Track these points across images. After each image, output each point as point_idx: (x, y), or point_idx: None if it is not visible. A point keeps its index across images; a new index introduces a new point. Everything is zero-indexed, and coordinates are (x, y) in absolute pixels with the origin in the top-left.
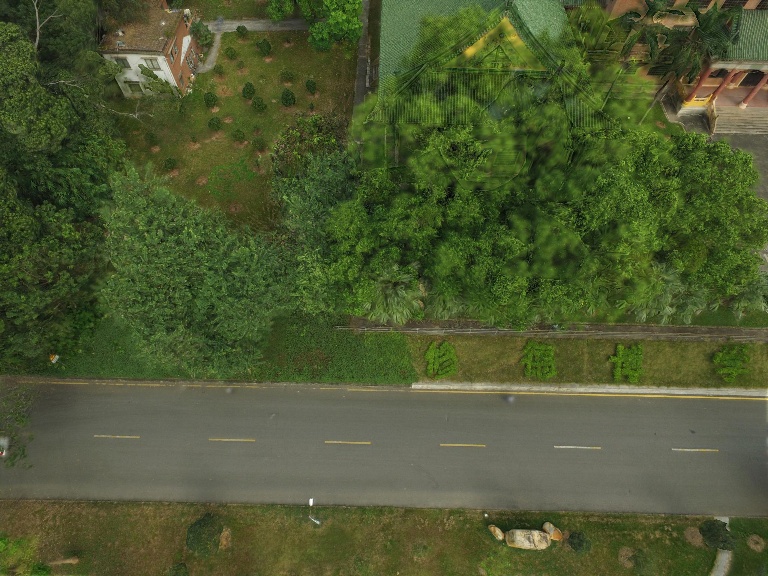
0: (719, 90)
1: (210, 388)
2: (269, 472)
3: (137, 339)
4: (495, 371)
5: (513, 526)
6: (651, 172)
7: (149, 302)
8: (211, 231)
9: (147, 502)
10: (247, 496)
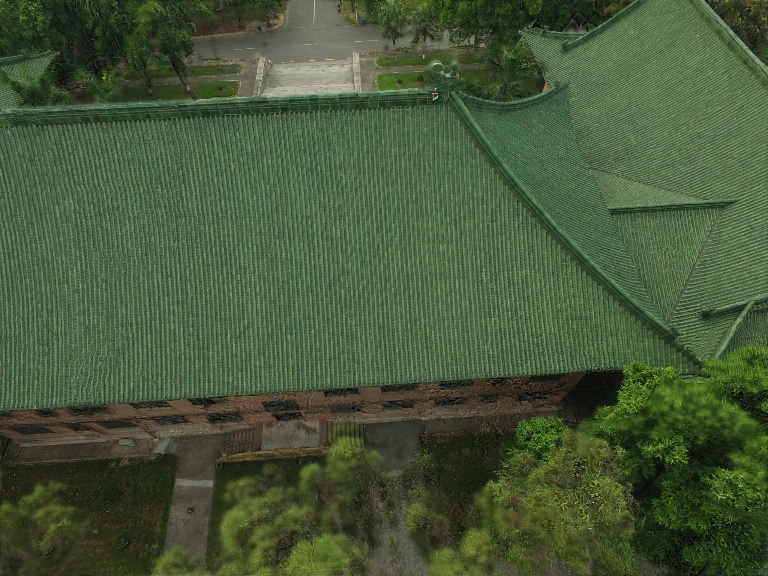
0: None
1: None
2: None
3: None
4: None
5: None
6: None
7: None
8: None
9: None
10: None
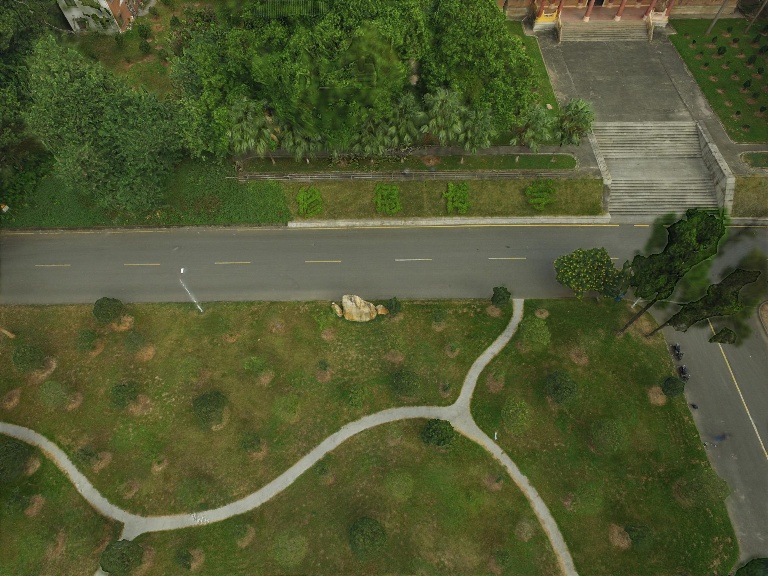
0: (561, 5)
1: (129, 233)
2: (169, 283)
3: (57, 164)
4: (353, 210)
5: None
6: (407, 3)
7: (60, 127)
8: (109, 80)
9: (72, 304)
10: (150, 298)
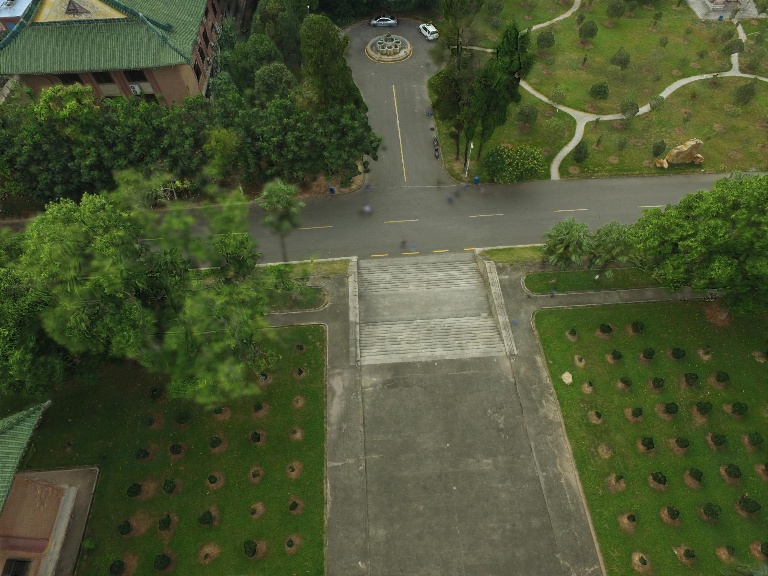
0: None
1: None
2: None
3: None
4: None
5: (685, 166)
6: None
7: None
8: None
9: None
10: None
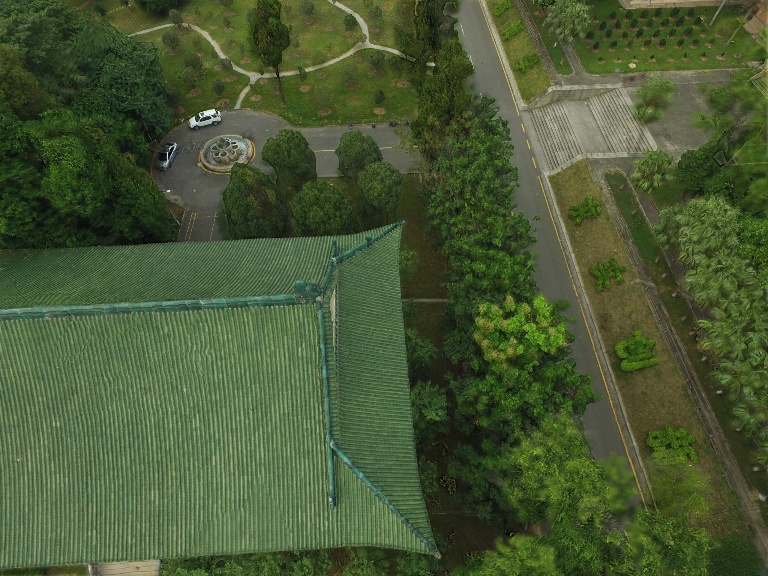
0: None
1: None
2: None
3: None
4: (493, 2)
5: None
6: None
7: None
8: None
9: None
10: None
